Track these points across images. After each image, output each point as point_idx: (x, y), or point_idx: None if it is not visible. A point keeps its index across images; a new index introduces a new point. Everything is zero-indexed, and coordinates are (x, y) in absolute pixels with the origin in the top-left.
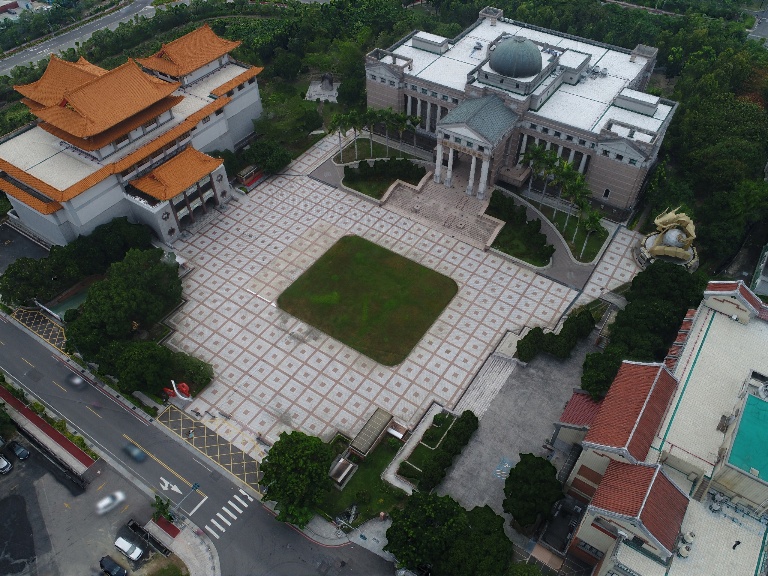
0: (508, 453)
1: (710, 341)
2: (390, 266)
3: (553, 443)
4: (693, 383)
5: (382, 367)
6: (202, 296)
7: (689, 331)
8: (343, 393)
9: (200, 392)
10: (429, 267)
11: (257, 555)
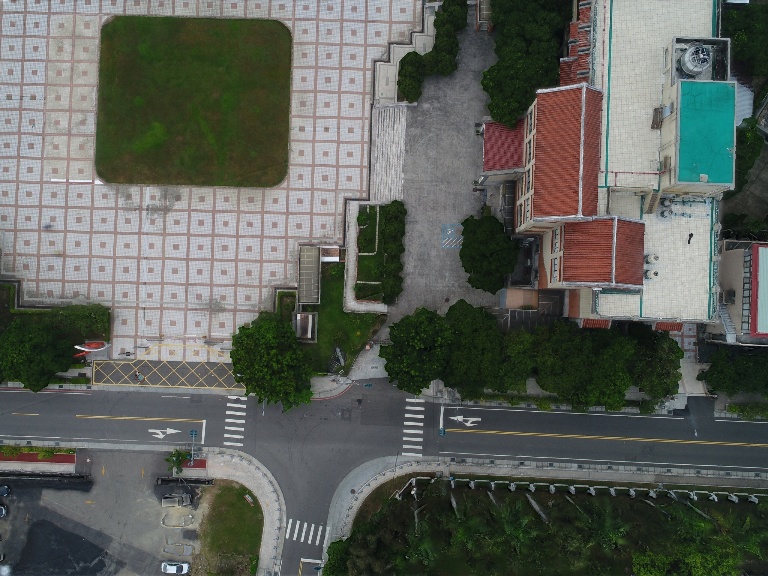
0: (445, 218)
1: (618, 7)
2: (191, 44)
3: (482, 184)
4: (615, 80)
5: (271, 191)
6: (8, 221)
7: (592, 3)
8: (252, 245)
9: (110, 331)
10: (237, 17)
11: (285, 438)
